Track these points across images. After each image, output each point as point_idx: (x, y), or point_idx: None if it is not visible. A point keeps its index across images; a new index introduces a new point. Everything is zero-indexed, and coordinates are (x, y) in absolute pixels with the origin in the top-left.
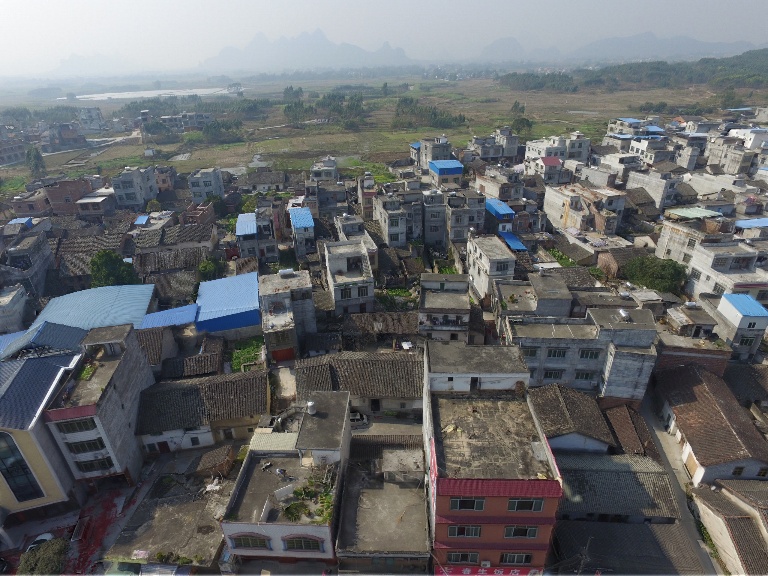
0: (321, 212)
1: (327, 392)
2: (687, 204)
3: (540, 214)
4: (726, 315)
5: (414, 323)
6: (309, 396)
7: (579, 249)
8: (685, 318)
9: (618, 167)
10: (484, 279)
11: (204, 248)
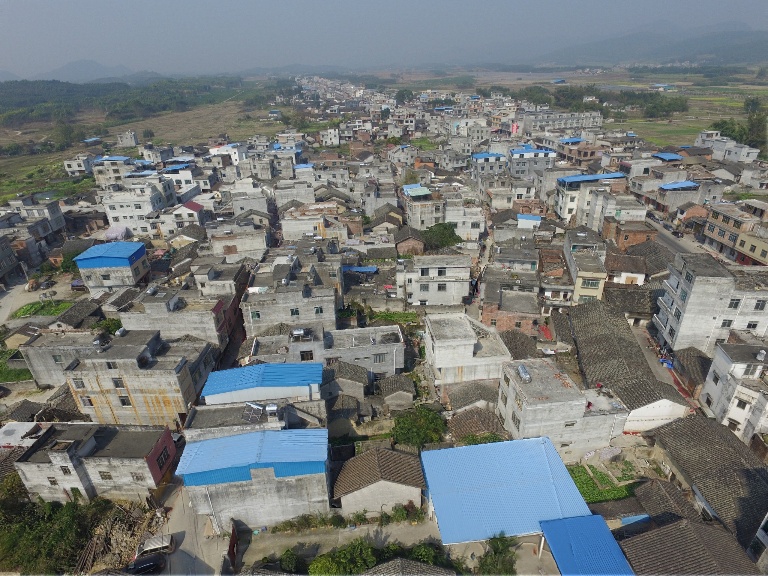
0: (192, 376)
1: (727, 353)
2: (329, 200)
3: (335, 239)
4: (527, 227)
5: (525, 337)
6: (740, 362)
7: (381, 250)
8: (547, 232)
9: (255, 191)
10: (458, 287)
11: (259, 572)
